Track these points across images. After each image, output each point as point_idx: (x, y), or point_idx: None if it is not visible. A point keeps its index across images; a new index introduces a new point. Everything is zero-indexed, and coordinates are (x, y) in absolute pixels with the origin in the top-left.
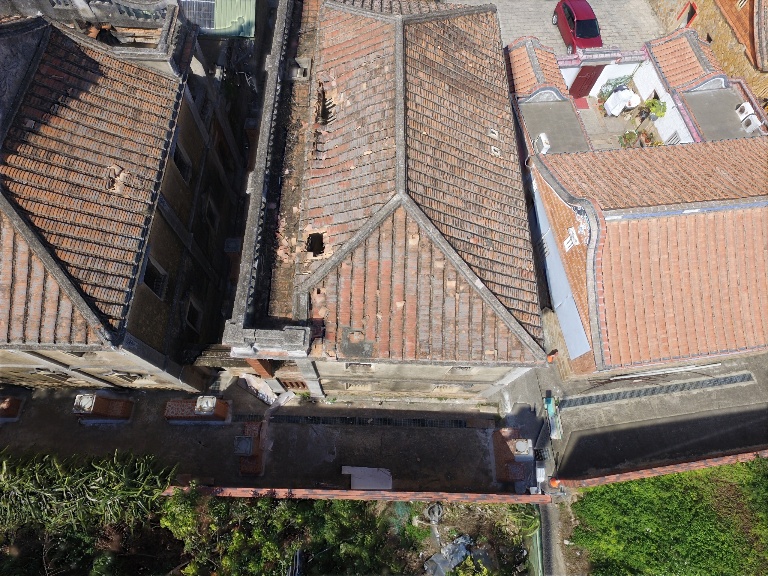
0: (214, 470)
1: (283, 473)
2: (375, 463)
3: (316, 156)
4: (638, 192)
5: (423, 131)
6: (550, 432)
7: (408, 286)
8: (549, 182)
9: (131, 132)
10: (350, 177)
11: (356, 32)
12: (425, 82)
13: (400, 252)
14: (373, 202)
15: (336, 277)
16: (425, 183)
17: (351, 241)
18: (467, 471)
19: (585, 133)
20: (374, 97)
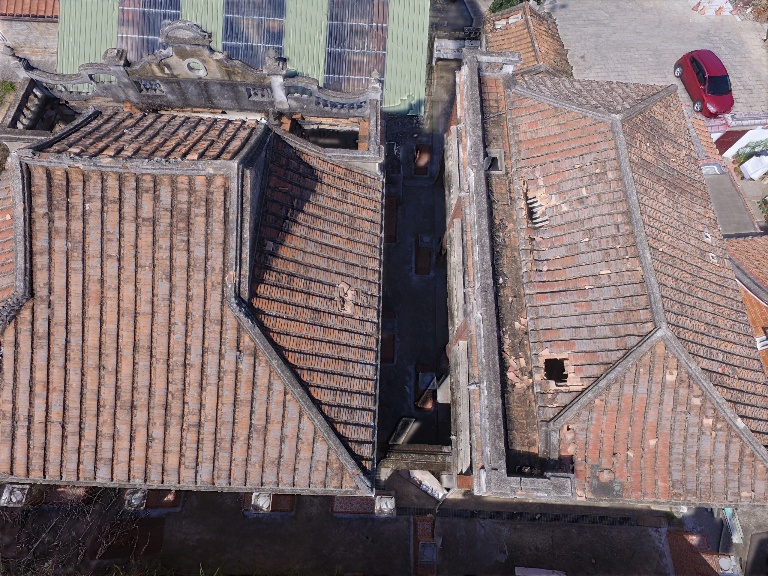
0: (385, 569)
1: (456, 574)
2: (549, 564)
3: (536, 267)
4: None
5: (659, 248)
6: (731, 535)
7: (662, 423)
8: (736, 275)
9: (350, 243)
10: (588, 298)
11: (560, 127)
12: (649, 189)
13: (657, 388)
14: (626, 333)
15: (588, 413)
16: (674, 310)
17: (609, 378)
18: (645, 575)
19: (749, 211)
20: (600, 207)
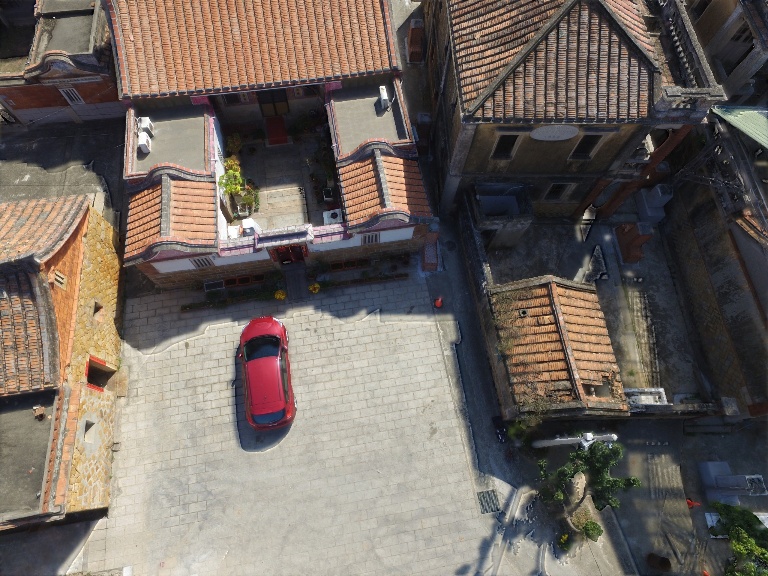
0: None
1: None
2: None
3: None
4: (328, 3)
5: None
6: None
7: None
8: None
9: None
10: None
11: None
12: None
13: None
14: None
15: None
16: None
17: None
18: None
19: (334, 119)
20: None
